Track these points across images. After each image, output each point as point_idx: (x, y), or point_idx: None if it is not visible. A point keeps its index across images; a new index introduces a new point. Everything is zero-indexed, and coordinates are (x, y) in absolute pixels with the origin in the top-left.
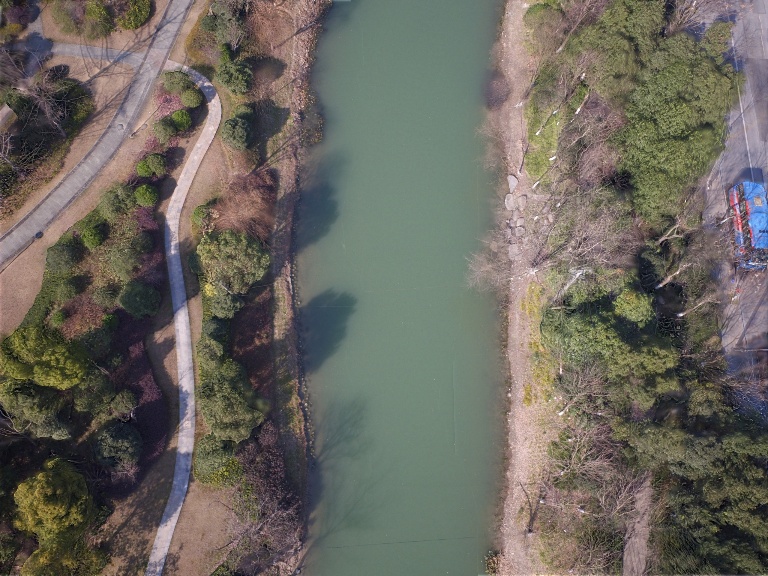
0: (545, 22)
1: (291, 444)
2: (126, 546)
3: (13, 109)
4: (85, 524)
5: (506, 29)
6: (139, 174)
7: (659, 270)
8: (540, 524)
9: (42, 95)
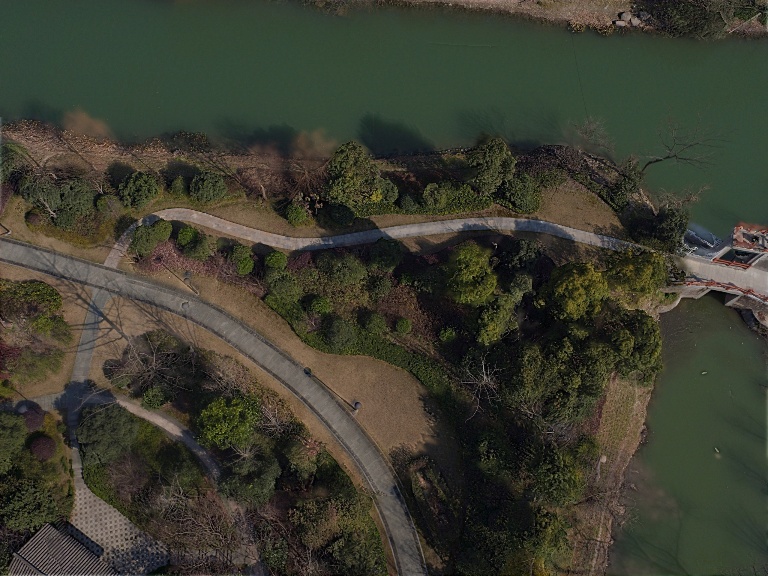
0: None
1: None
2: None
3: (165, 401)
4: None
5: None
6: (251, 270)
7: None
8: None
9: (149, 373)
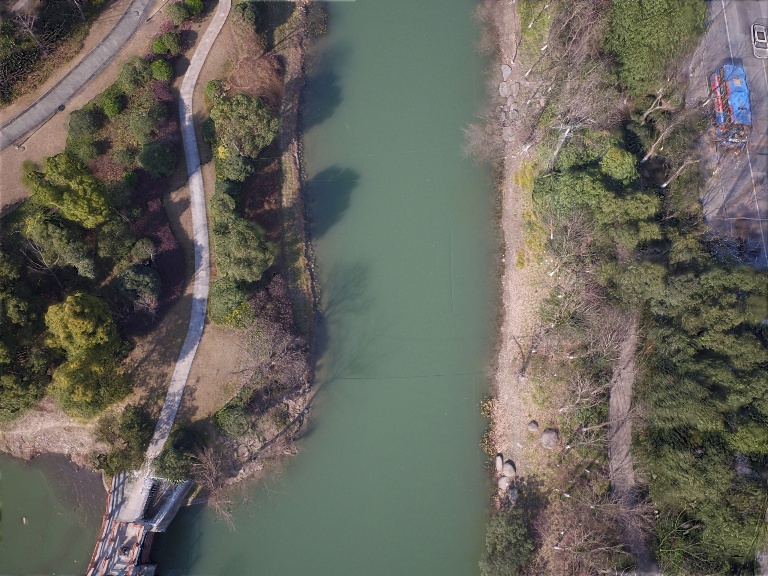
0: None
1: (299, 298)
2: (147, 378)
3: None
4: (110, 347)
5: None
6: (155, 51)
7: (643, 139)
8: (532, 370)
9: None
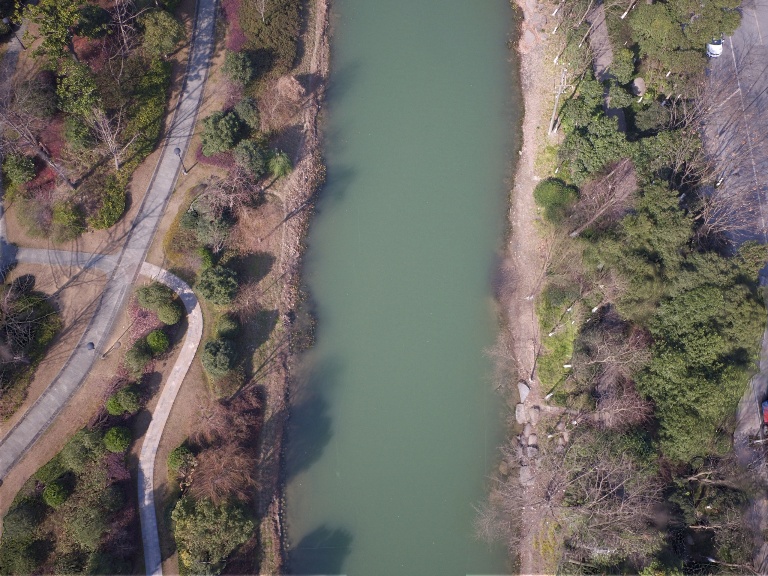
0: (557, 203)
1: None
2: None
3: None
4: None
5: (515, 204)
6: (109, 412)
7: (689, 520)
8: None
9: (3, 319)
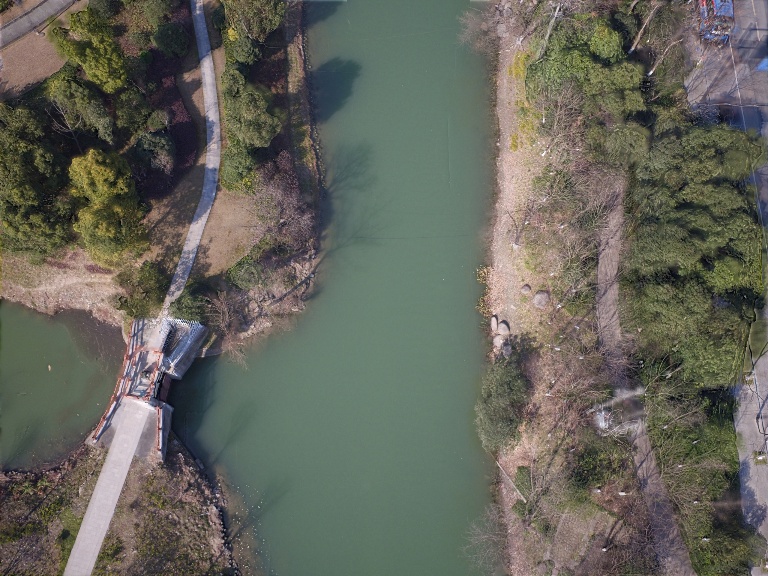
0: None
1: (305, 174)
2: (163, 237)
3: None
4: (129, 200)
5: None
6: None
7: (630, 26)
8: (525, 239)
9: None
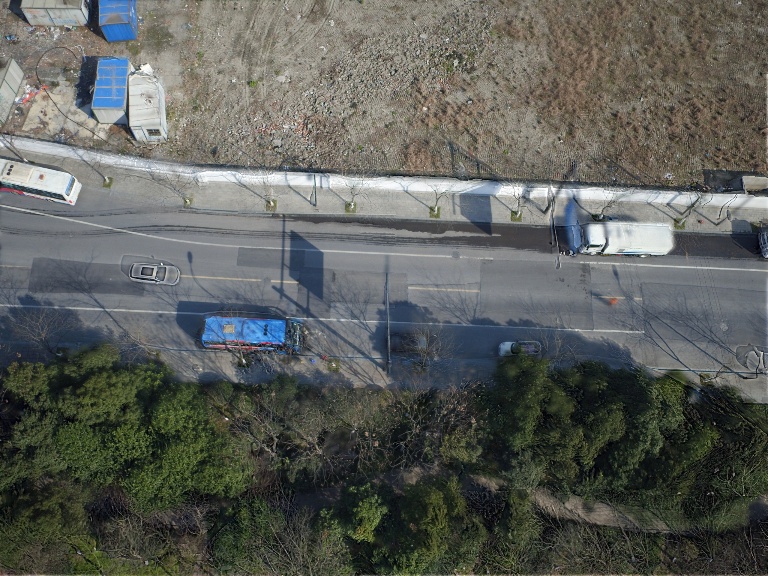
0: None
1: None
2: None
3: None
4: None
5: None
6: None
7: (312, 466)
8: None
9: None
